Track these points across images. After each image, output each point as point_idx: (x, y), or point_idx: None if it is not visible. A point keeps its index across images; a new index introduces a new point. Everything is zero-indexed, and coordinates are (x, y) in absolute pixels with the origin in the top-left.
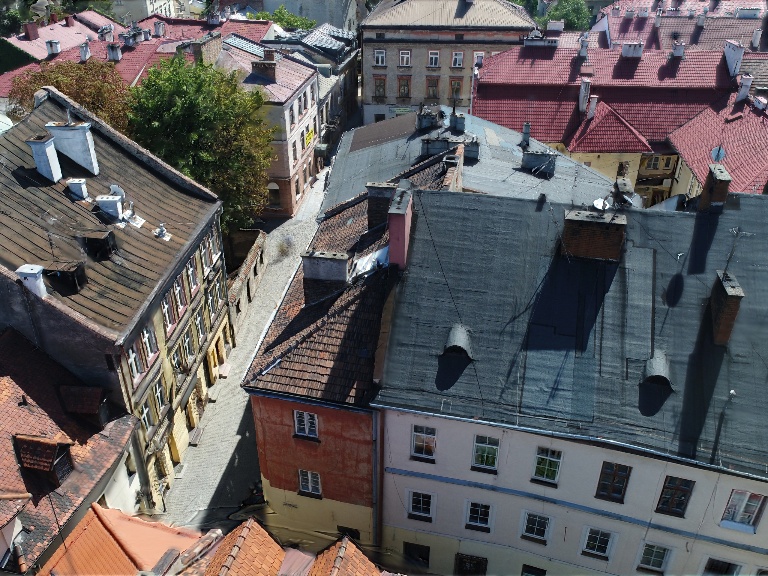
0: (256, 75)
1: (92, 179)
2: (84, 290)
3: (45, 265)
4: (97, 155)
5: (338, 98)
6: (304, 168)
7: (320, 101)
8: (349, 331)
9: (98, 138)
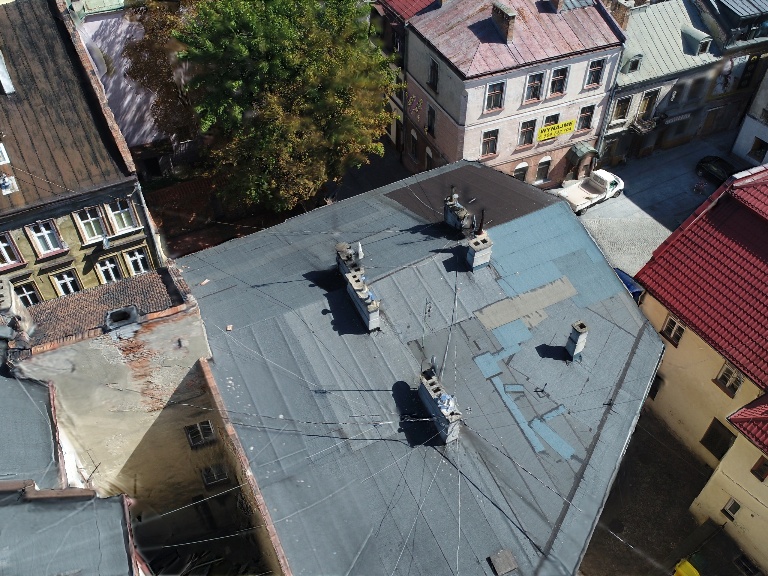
0: (493, 22)
1: None
2: None
3: None
4: (39, 71)
5: (673, 92)
6: (521, 166)
7: (617, 87)
8: None
9: (64, 52)
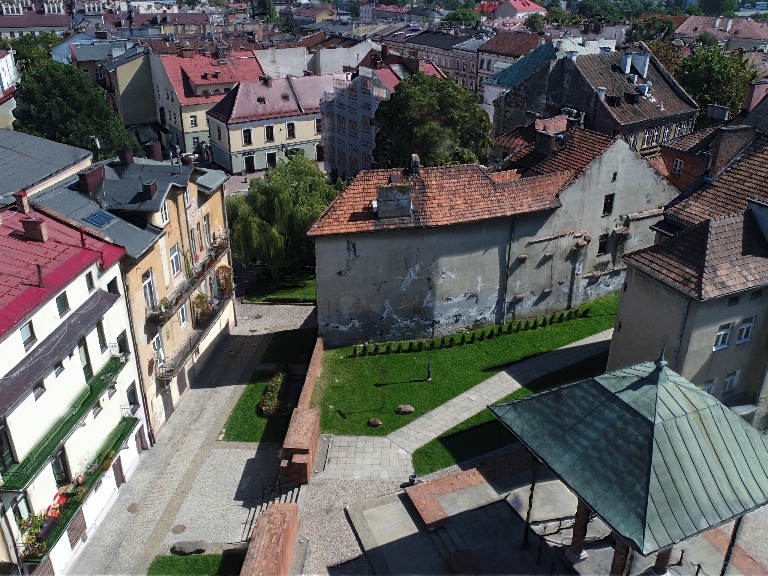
0: None
1: (642, 79)
2: (617, 108)
3: (608, 94)
4: (649, 72)
5: None
6: None
7: None
8: (713, 133)
9: (653, 67)
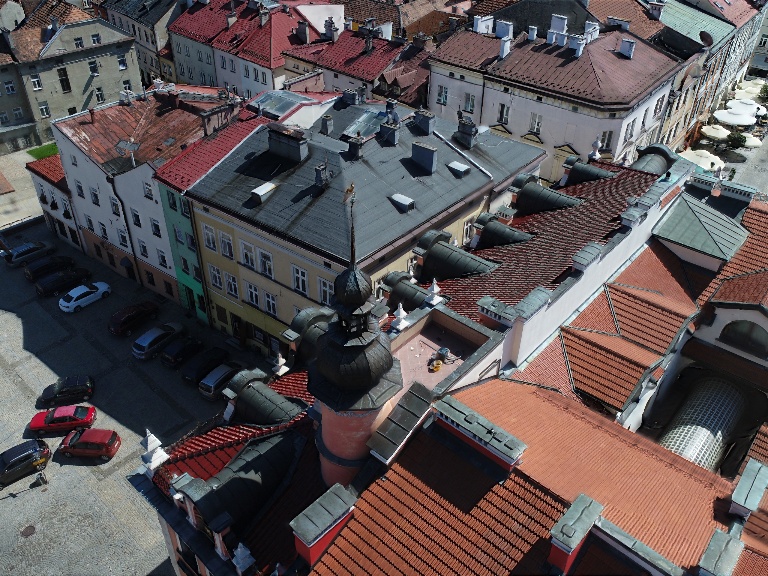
0: None
1: None
2: None
3: None
4: None
5: None
6: None
7: None
8: None
9: None
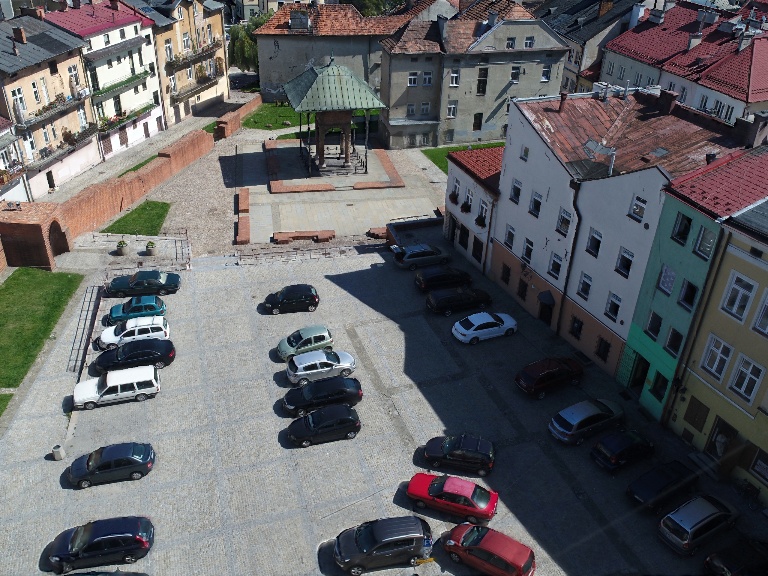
0: None
1: None
2: None
3: None
4: None
5: None
6: None
7: None
8: None
9: None
